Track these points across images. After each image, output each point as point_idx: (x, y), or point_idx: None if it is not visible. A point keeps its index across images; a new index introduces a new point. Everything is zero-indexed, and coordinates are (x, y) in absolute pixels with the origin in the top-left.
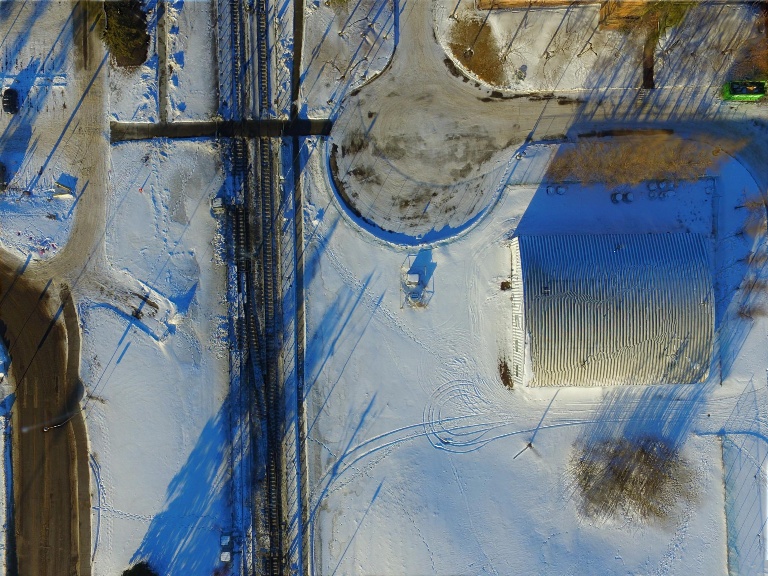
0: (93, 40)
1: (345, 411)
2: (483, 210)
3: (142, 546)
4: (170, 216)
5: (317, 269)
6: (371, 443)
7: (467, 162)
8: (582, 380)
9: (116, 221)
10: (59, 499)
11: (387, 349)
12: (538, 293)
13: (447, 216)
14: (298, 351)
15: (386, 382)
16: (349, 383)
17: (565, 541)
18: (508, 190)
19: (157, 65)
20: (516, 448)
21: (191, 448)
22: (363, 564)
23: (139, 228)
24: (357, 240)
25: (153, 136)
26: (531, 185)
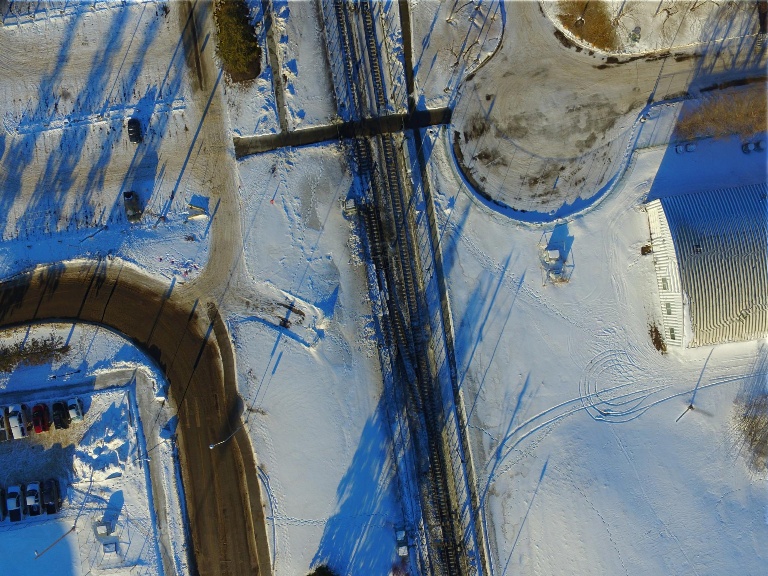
0: (205, 60)
1: (500, 395)
2: (613, 178)
3: (320, 550)
4: (304, 223)
5: (455, 257)
6: (531, 423)
7: (591, 132)
8: (740, 335)
9: (252, 235)
10: (232, 513)
11: (535, 328)
12: (690, 252)
13: (577, 188)
14: (447, 341)
15: (538, 361)
16: (501, 366)
17: (739, 498)
18: (637, 154)
19: (271, 76)
20: (677, 411)
21: (354, 449)
22: (539, 543)
23: (275, 239)
24: (491, 224)
25: (277, 147)
26: (659, 146)
